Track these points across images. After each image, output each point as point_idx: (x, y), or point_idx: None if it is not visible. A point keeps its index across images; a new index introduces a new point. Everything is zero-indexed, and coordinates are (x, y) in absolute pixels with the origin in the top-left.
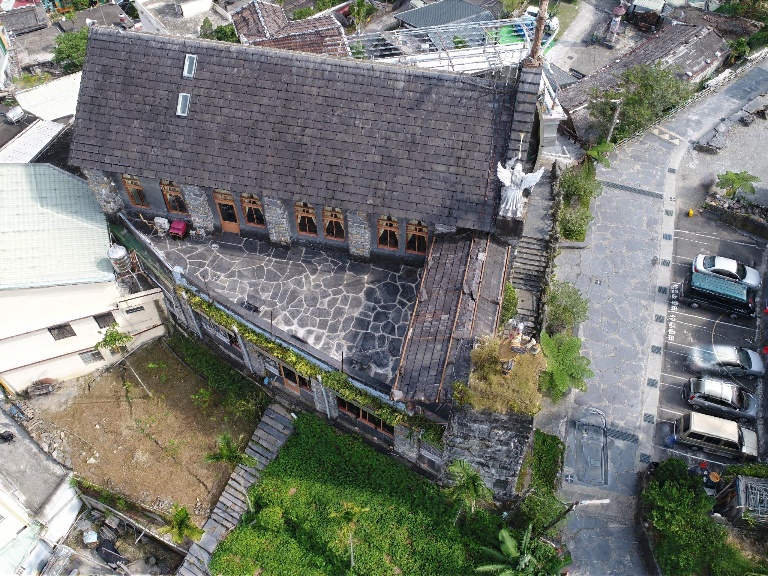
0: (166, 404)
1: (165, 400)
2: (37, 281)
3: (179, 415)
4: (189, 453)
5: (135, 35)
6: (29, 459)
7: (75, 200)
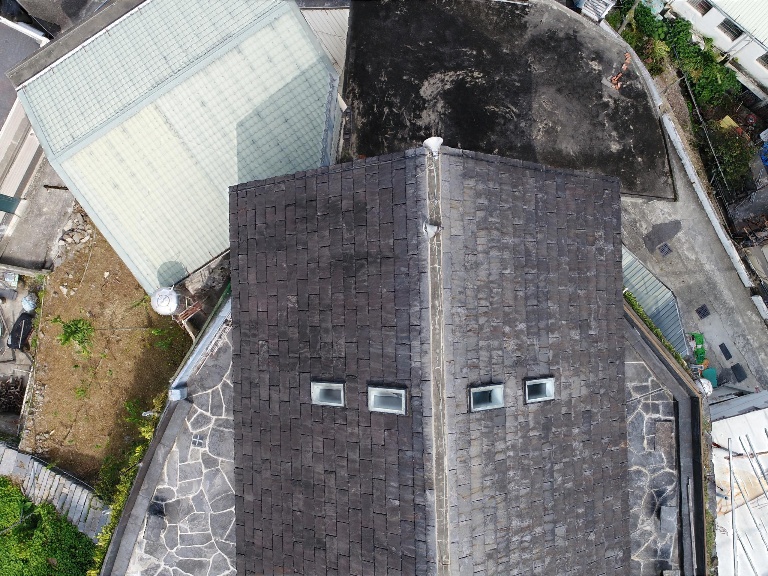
0: (143, 351)
1: (147, 349)
2: (93, 206)
3: (133, 374)
4: (97, 402)
5: (425, 259)
6: (57, 211)
7: (279, 161)
